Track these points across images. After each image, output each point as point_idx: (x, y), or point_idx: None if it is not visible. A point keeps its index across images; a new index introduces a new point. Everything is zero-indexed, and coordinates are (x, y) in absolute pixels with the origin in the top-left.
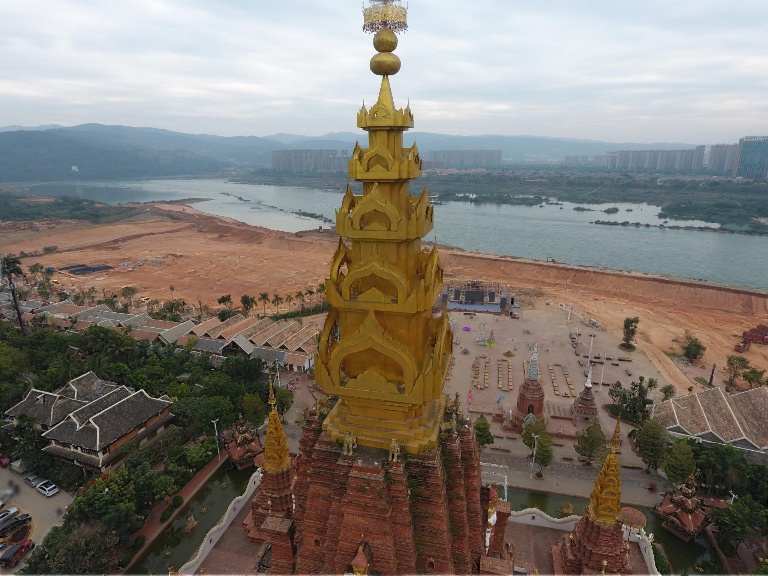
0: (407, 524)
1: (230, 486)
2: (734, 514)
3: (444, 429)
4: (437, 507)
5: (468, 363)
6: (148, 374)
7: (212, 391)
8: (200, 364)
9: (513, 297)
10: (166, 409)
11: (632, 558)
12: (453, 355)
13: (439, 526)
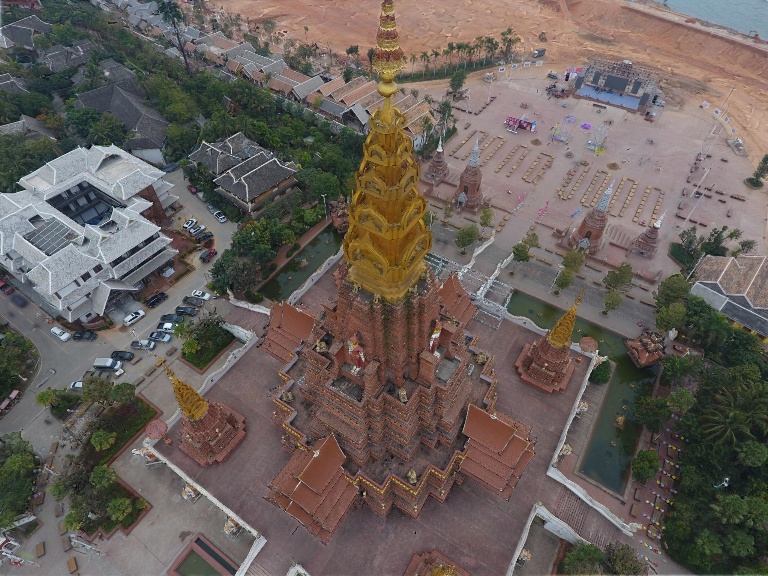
0: (380, 330)
1: (331, 243)
2: (676, 363)
3: (410, 291)
4: (397, 327)
5: (565, 168)
6: (282, 135)
7: (327, 163)
8: (322, 130)
9: (658, 94)
10: (292, 176)
11: (580, 366)
12: (555, 156)
13: (397, 334)
